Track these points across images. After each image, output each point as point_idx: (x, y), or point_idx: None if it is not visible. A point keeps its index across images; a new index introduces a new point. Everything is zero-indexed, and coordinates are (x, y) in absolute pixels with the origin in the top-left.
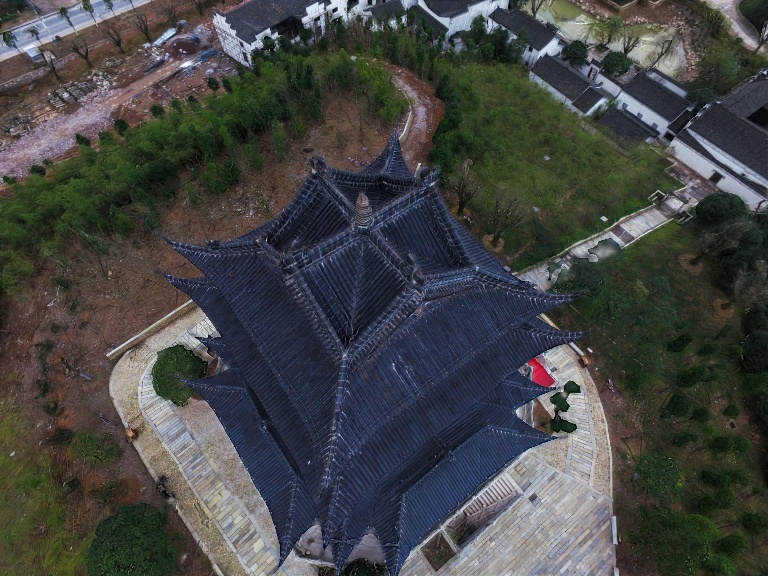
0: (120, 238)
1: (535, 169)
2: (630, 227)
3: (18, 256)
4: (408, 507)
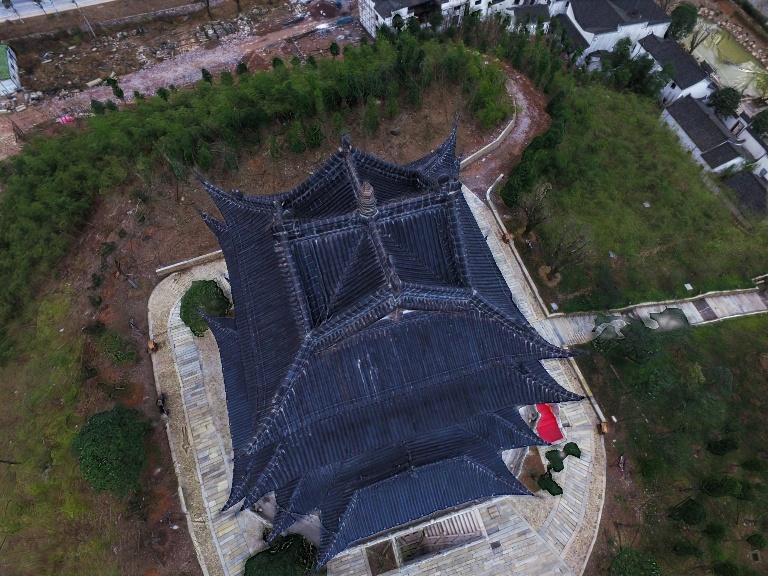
0: (201, 170)
1: (628, 213)
2: (717, 304)
3: (117, 163)
4: (358, 504)
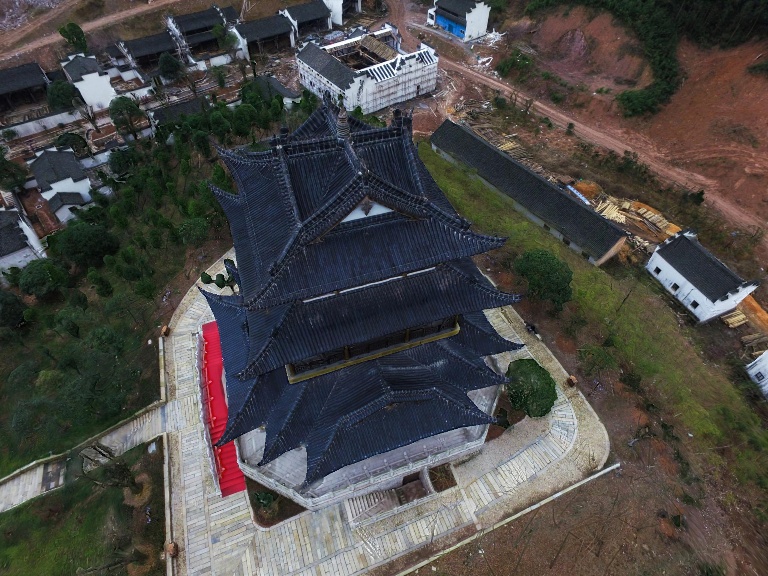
0: None
1: None
2: None
3: None
4: None
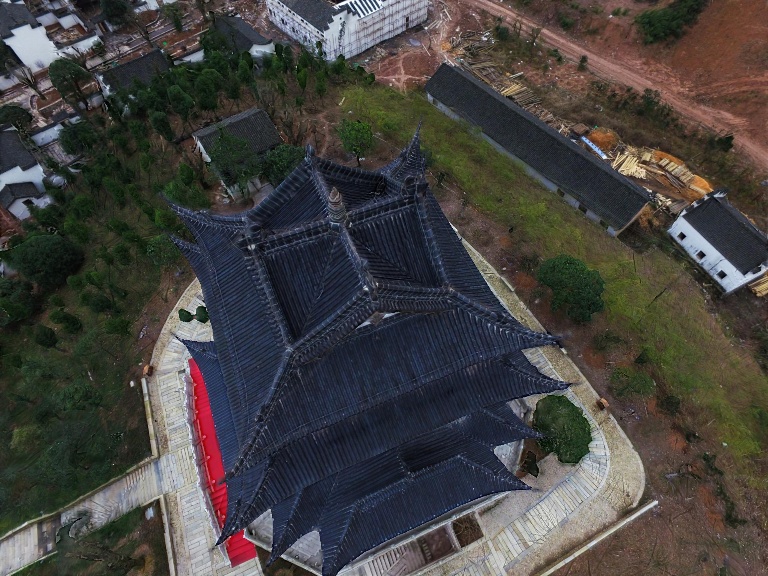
0: None
1: None
2: None
3: None
4: None
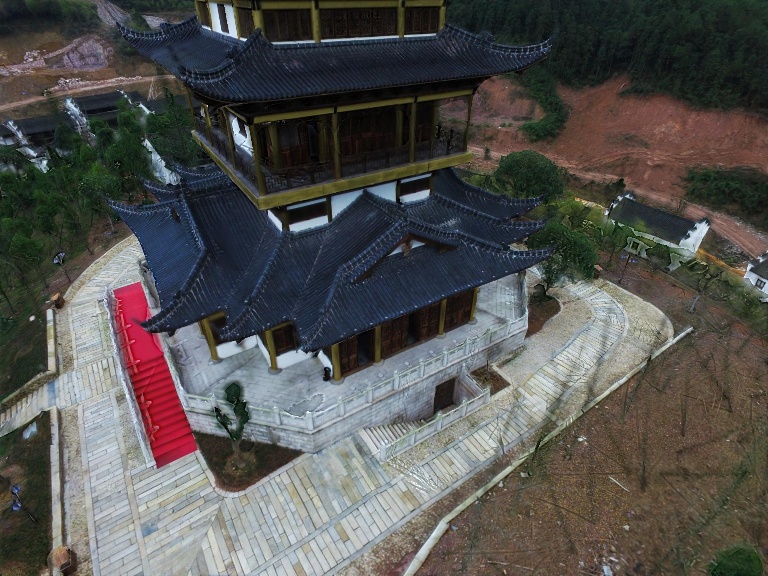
0: None
1: None
2: None
3: None
4: None
